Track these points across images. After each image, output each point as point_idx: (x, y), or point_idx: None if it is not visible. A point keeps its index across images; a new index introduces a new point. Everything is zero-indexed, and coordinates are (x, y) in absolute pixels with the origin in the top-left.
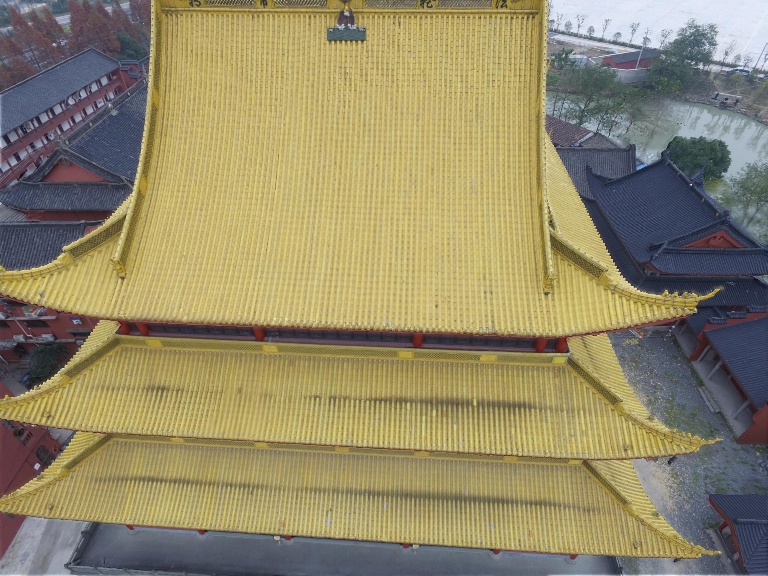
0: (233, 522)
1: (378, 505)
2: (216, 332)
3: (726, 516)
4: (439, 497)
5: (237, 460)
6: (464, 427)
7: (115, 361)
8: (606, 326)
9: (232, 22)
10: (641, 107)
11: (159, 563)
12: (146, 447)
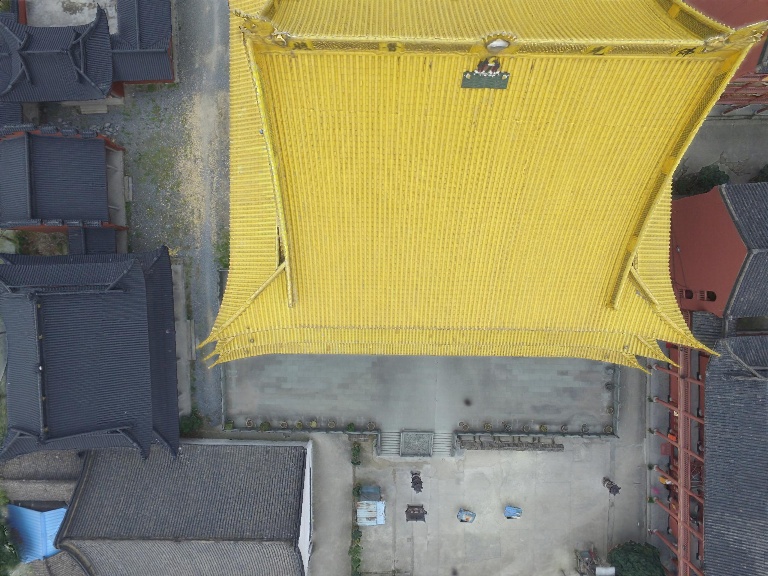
0: None
1: None
2: None
3: None
4: None
5: None
6: None
7: None
8: None
9: None
10: None
11: None
12: None
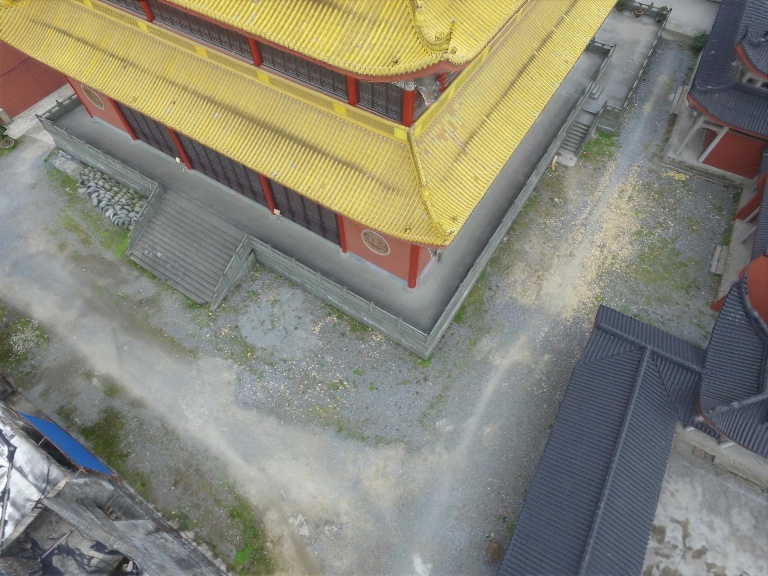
0: (103, 85)
1: (211, 113)
2: None
3: (595, 321)
4: (263, 125)
5: (125, 37)
6: (260, 8)
7: None
8: None
9: None
10: None
11: (97, 145)
12: (69, 5)
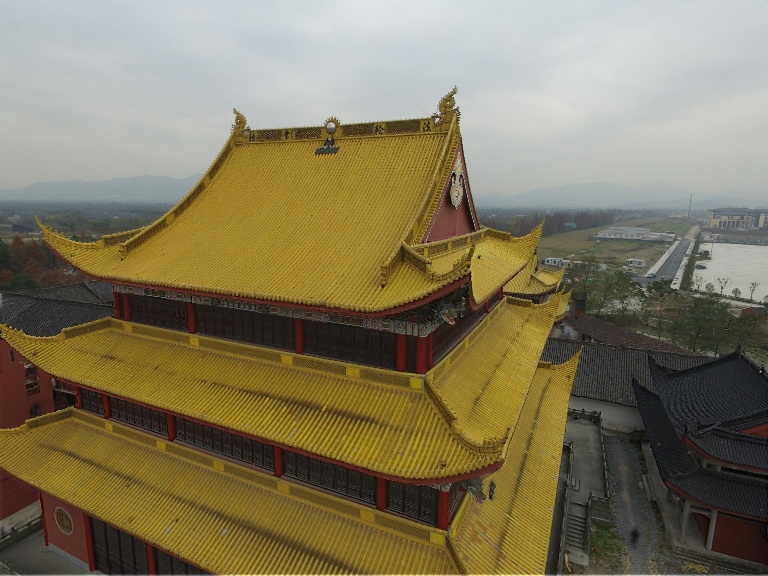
0: (97, 505)
1: (219, 529)
2: (168, 325)
3: None
4: (279, 540)
5: (138, 456)
6: (302, 425)
7: (99, 337)
8: (408, 298)
9: (268, 148)
10: (750, 330)
11: None
12: (87, 430)
